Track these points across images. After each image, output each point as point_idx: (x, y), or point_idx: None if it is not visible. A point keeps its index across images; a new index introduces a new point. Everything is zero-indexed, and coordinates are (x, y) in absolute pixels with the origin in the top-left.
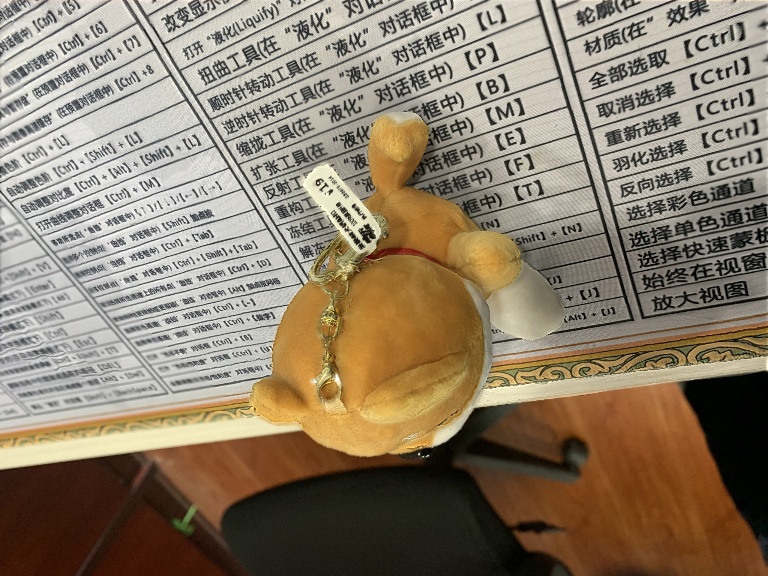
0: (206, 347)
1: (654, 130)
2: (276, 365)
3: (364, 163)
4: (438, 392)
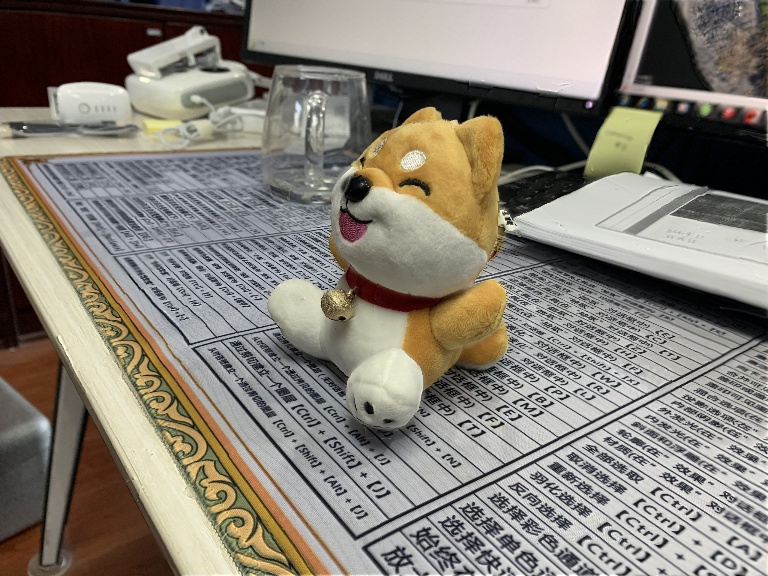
0: (186, 277)
1: (584, 490)
2: None
3: None
4: (494, 153)
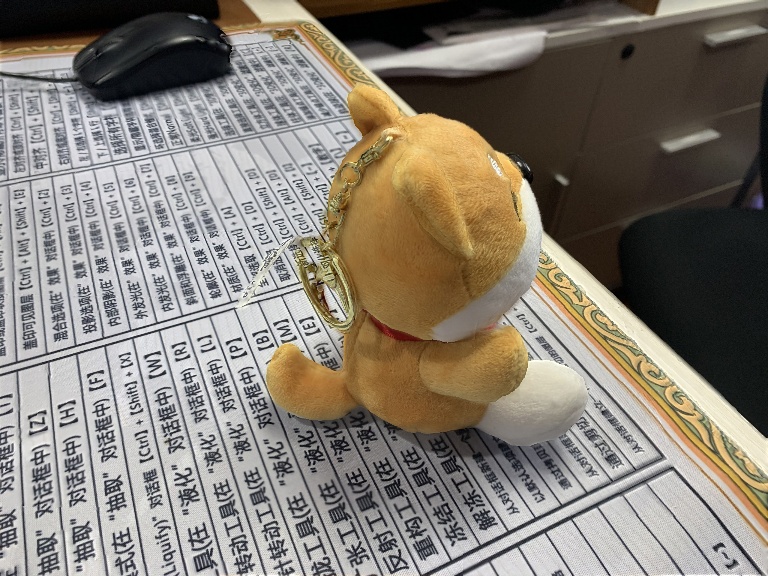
0: None
1: (300, 253)
2: (415, 235)
3: (342, 442)
4: None
